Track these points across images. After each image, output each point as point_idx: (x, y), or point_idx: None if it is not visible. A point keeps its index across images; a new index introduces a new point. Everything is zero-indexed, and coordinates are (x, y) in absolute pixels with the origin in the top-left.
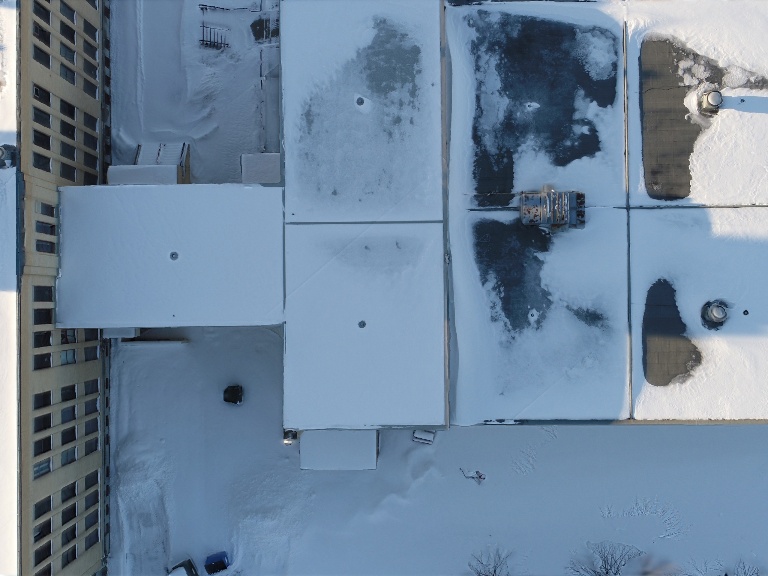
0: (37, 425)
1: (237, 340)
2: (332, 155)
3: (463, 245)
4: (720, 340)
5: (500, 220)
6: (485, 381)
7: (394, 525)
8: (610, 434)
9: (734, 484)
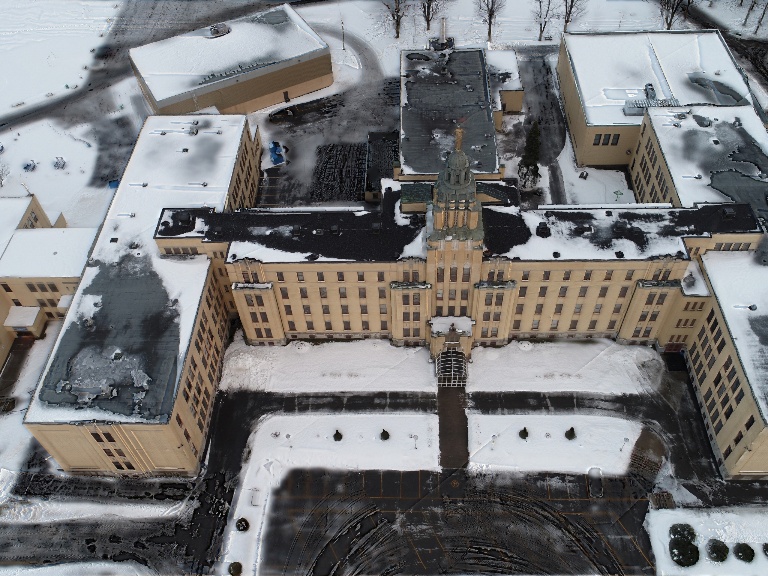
0: None
1: None
2: None
3: None
4: None
5: None
6: None
7: None
8: None
9: None
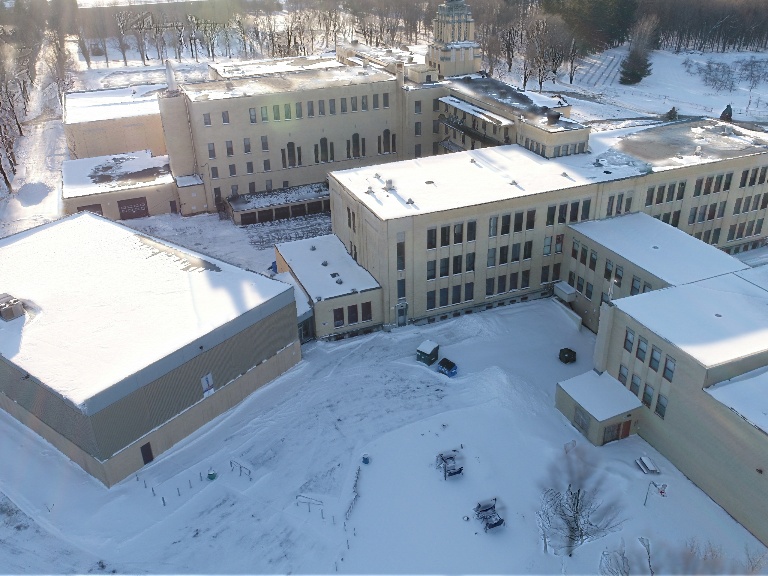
0: (518, 217)
1: None
2: None
3: None
4: None
5: None
6: (761, 401)
7: (555, 469)
8: None
9: None
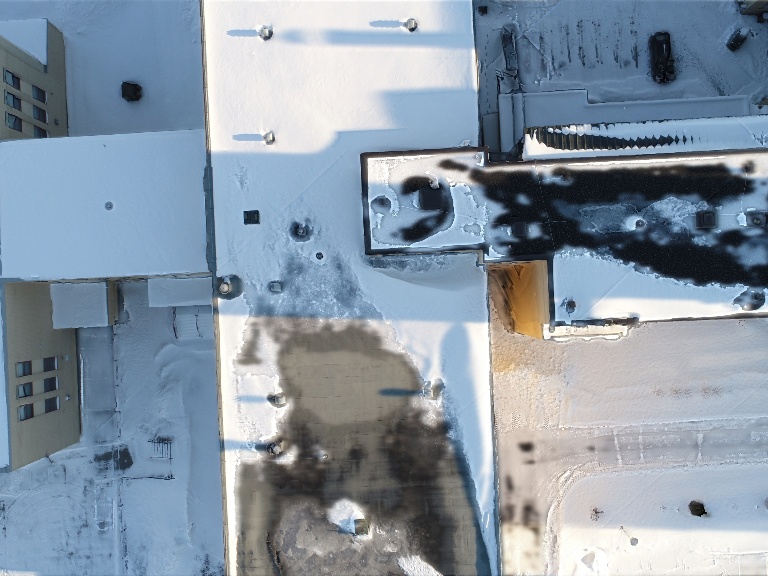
0: None
1: None
2: None
3: None
4: None
5: None
6: None
7: None
8: None
9: None
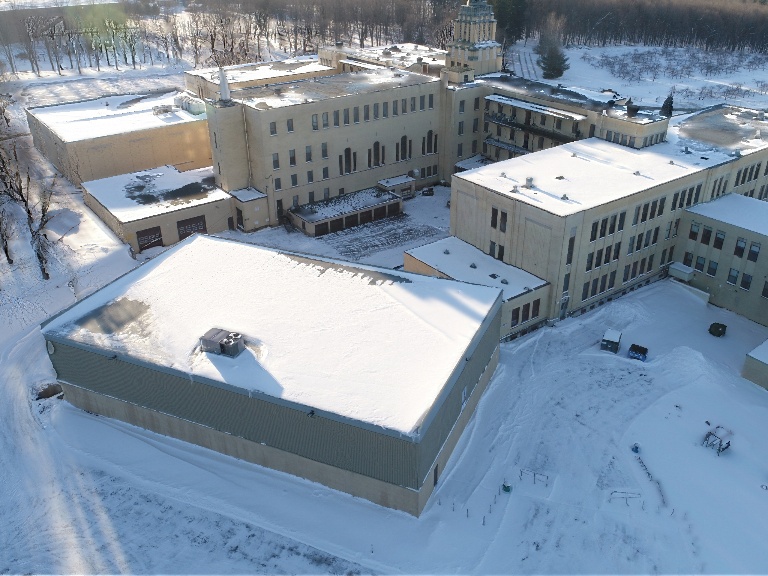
0: (654, 205)
1: None
2: None
3: None
4: None
5: None
6: None
7: None
8: None
9: None
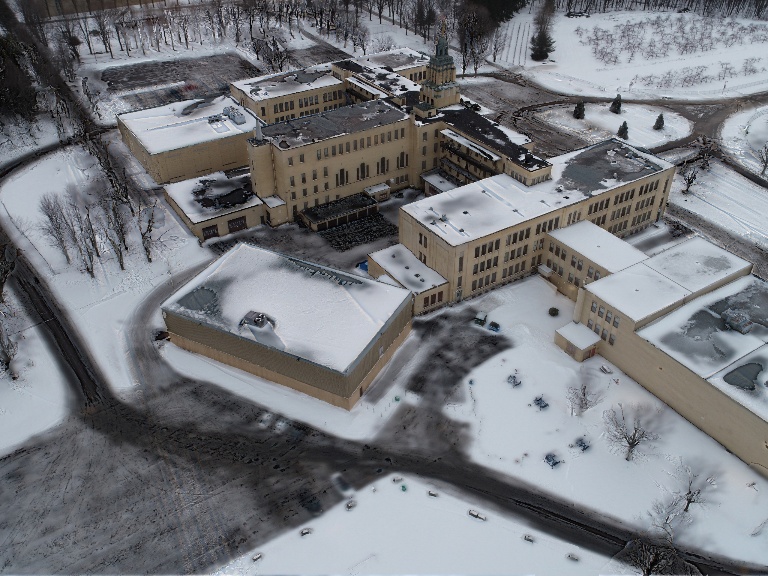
0: None
1: (572, 306)
2: (674, 263)
3: (693, 309)
4: (767, 391)
5: (713, 315)
6: (660, 335)
7: (563, 376)
8: (684, 431)
9: (725, 481)
